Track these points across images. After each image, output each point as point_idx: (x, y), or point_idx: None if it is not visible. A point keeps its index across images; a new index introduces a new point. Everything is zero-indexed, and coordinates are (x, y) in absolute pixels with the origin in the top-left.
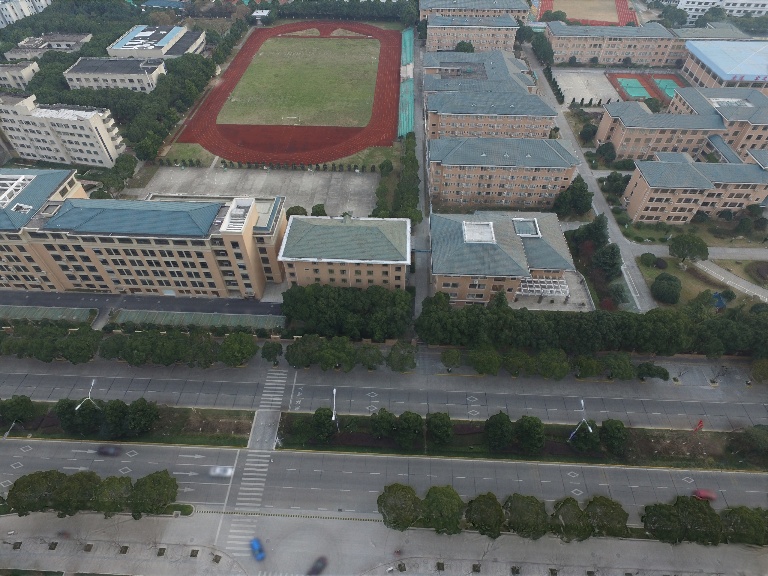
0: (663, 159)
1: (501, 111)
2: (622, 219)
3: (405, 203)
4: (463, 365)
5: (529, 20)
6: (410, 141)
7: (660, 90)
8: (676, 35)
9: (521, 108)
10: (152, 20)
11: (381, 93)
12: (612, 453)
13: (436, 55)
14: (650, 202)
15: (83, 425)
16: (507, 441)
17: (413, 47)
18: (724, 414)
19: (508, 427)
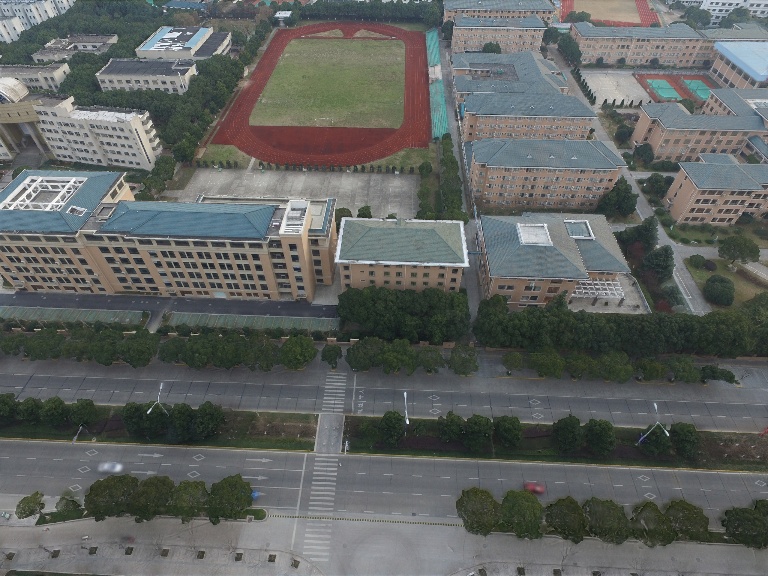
0: (708, 160)
1: (540, 112)
2: (667, 221)
3: (450, 205)
4: (525, 368)
5: (553, 21)
6: (448, 142)
7: (690, 91)
8: (704, 36)
9: (560, 109)
10: (177, 21)
11: (411, 94)
12: (682, 456)
13: (465, 56)
14: (696, 204)
15: (150, 429)
16: (578, 445)
17: (439, 48)
18: None
19: (579, 430)
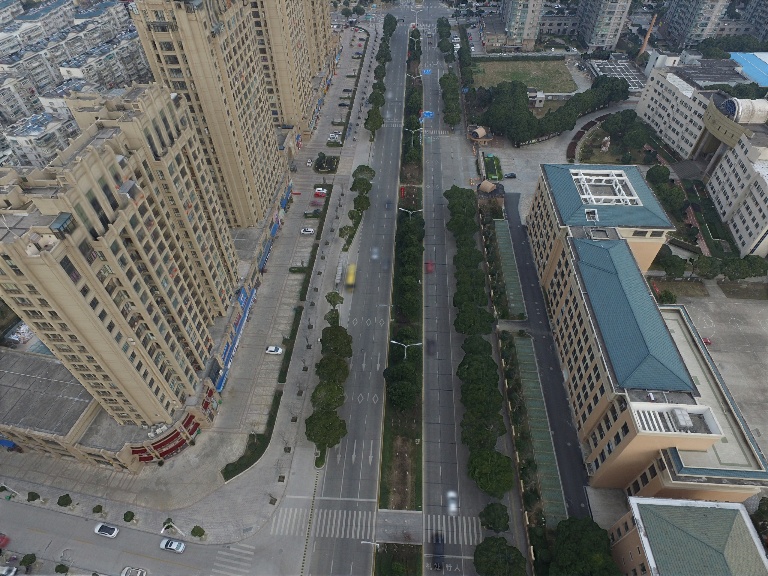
0: None
1: None
2: None
3: None
4: None
5: None
6: None
7: None
8: None
9: None
10: None
11: None
12: None
13: None
14: None
15: None
16: None
17: None
18: None
19: None
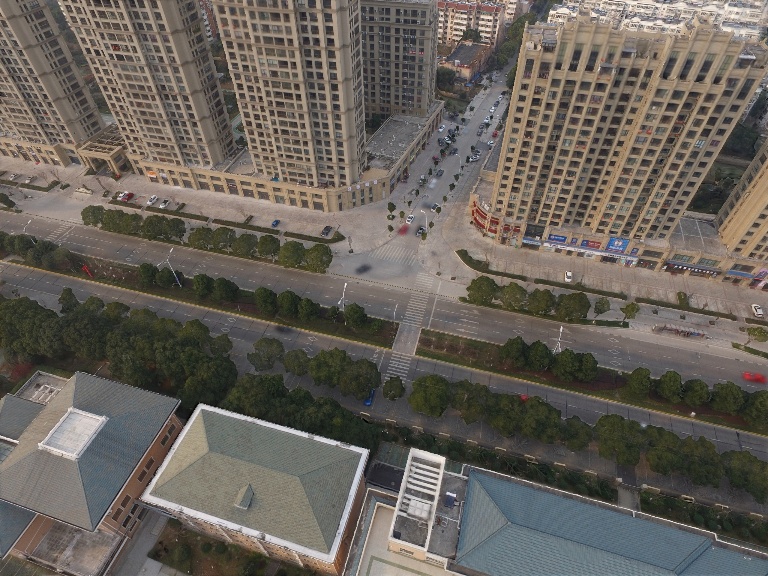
0: None
1: None
2: None
3: None
4: None
5: None
6: None
7: None
8: None
9: None
10: None
11: None
12: None
13: None
14: None
15: None
16: None
17: None
18: (52, 285)
19: None
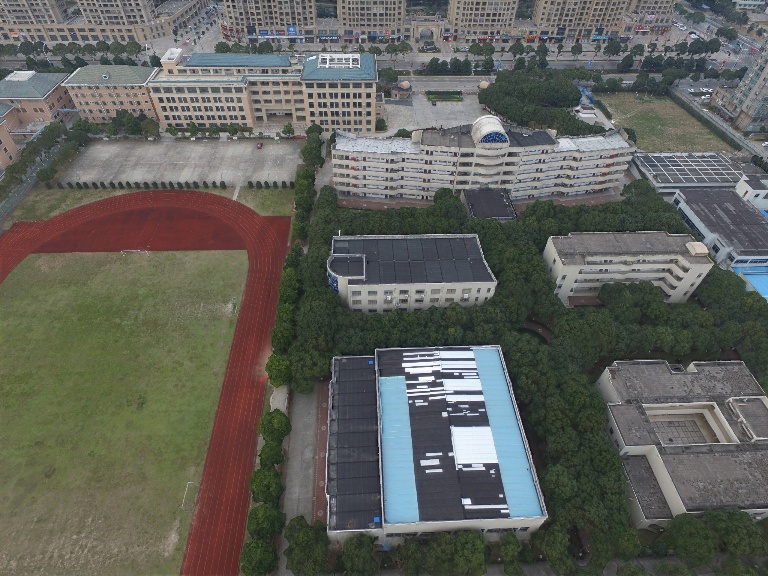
0: None
1: None
2: None
3: None
4: None
5: None
6: None
7: None
8: None
9: None
10: None
11: None
12: None
13: None
14: None
15: None
16: None
17: None
18: None
19: None
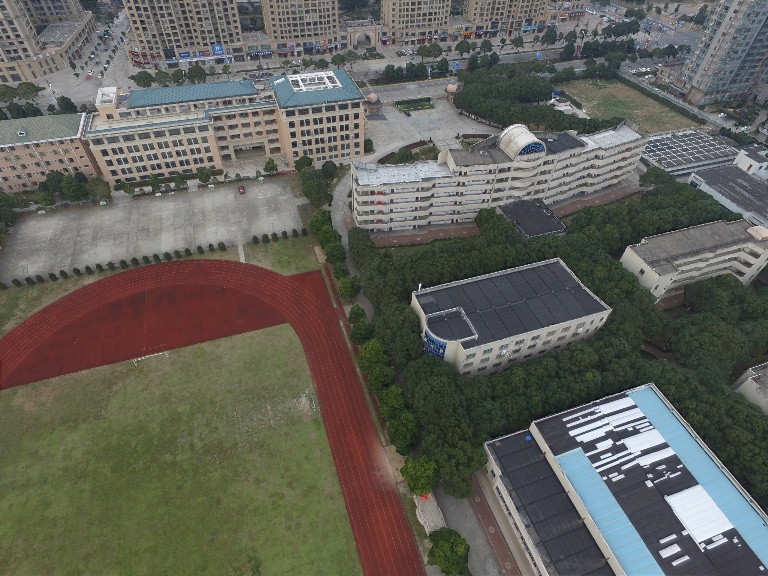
0: None
1: None
2: None
3: None
4: None
5: None
6: None
7: None
8: None
9: None
10: None
11: None
12: None
13: None
14: None
15: None
16: None
17: None
18: None
19: None
